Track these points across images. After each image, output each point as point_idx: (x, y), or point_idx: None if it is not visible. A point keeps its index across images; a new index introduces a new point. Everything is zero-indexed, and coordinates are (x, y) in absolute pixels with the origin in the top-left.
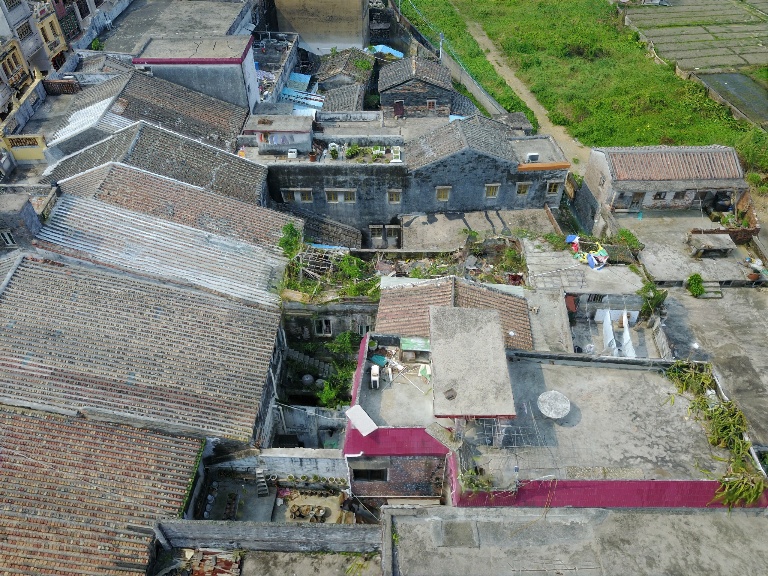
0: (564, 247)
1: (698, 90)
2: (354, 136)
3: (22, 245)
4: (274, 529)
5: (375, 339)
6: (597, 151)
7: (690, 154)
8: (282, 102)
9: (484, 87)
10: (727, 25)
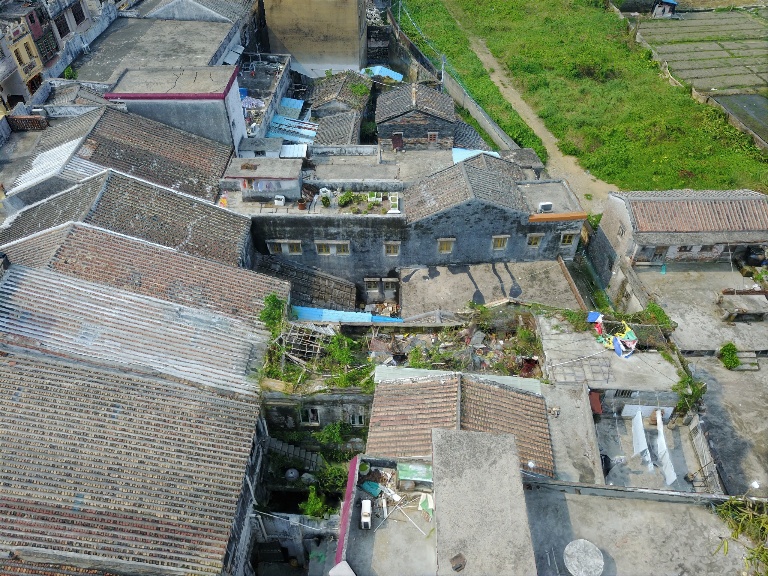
0: (586, 328)
1: (717, 116)
2: (348, 180)
3: None
4: None
5: (367, 461)
6: (616, 197)
7: (719, 202)
8: (272, 132)
9: (489, 112)
10: (743, 41)
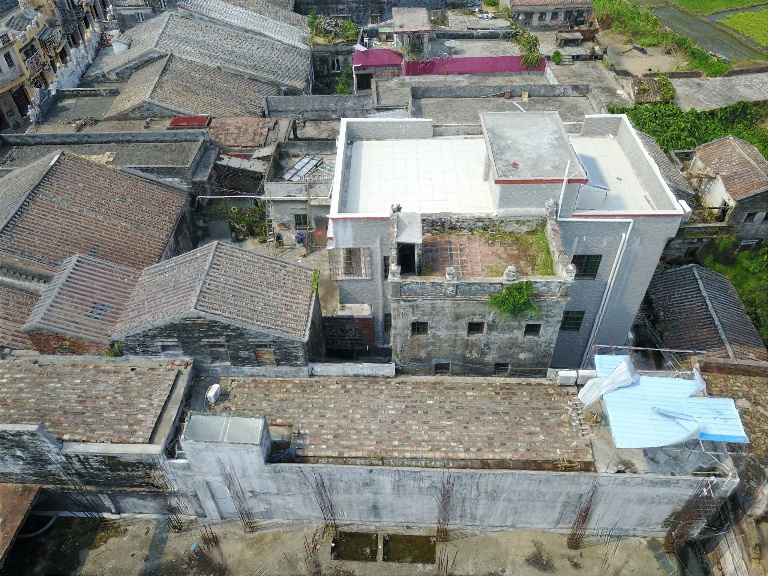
0: (470, 13)
1: None
2: None
3: (170, 7)
4: (321, 99)
5: (366, 32)
6: None
7: None
8: None
9: None
10: None
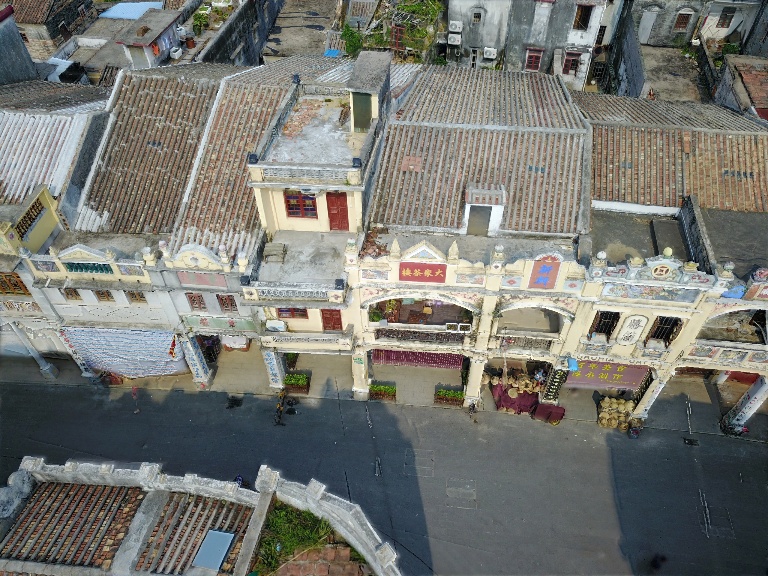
0: None
1: None
2: None
3: None
4: None
5: None
6: None
7: None
8: None
9: None
10: None
